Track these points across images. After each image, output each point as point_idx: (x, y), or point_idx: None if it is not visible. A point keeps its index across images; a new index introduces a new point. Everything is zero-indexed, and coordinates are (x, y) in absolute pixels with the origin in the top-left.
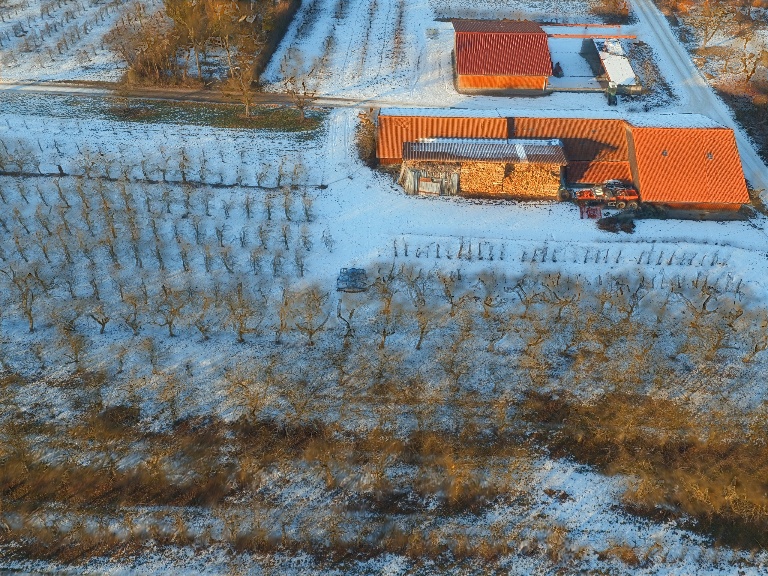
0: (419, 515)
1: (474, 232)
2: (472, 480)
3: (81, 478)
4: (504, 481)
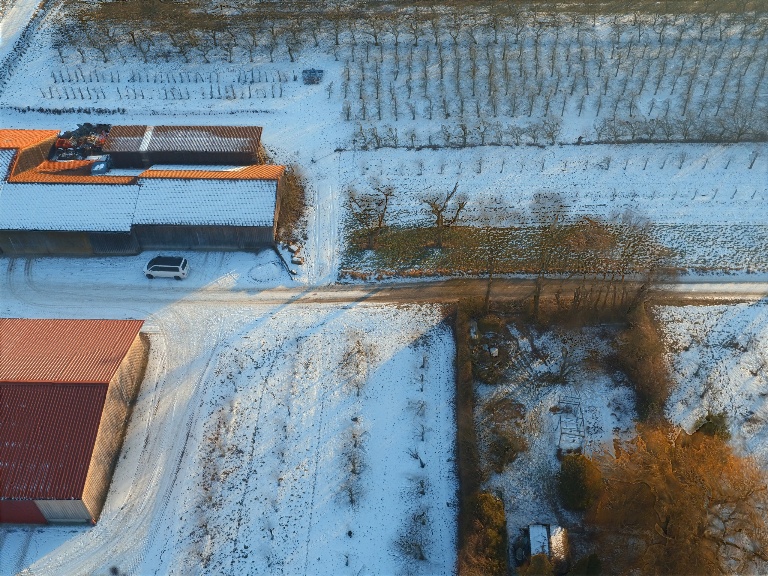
0: None
1: (215, 121)
2: None
3: (430, 4)
4: None
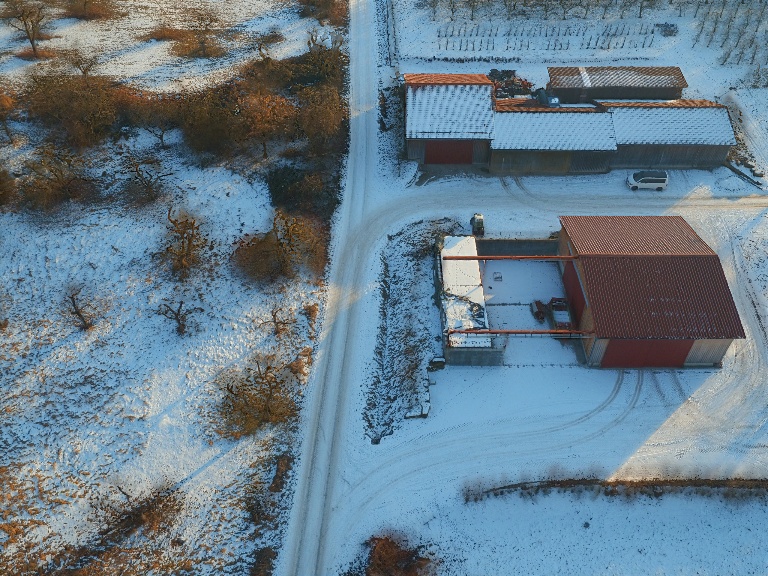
0: None
1: None
2: None
3: None
4: None
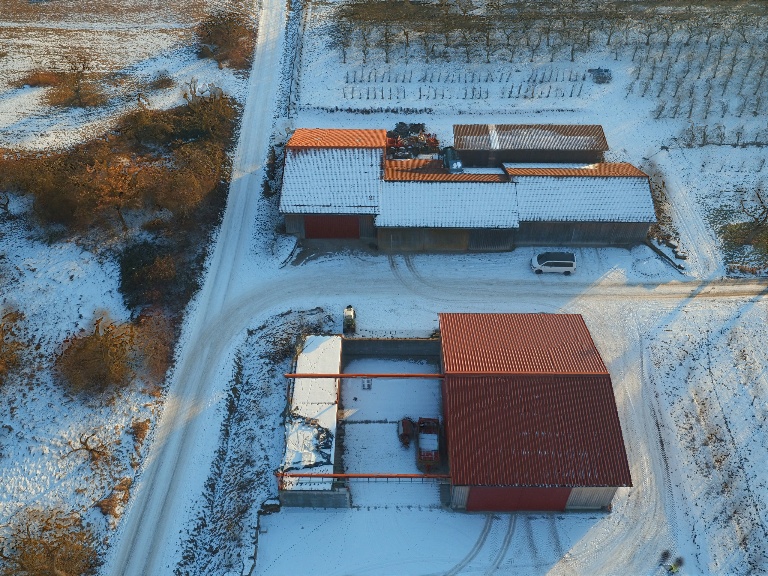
0: (533, 2)
1: (524, 120)
2: (513, 9)
3: (677, 4)
4: None
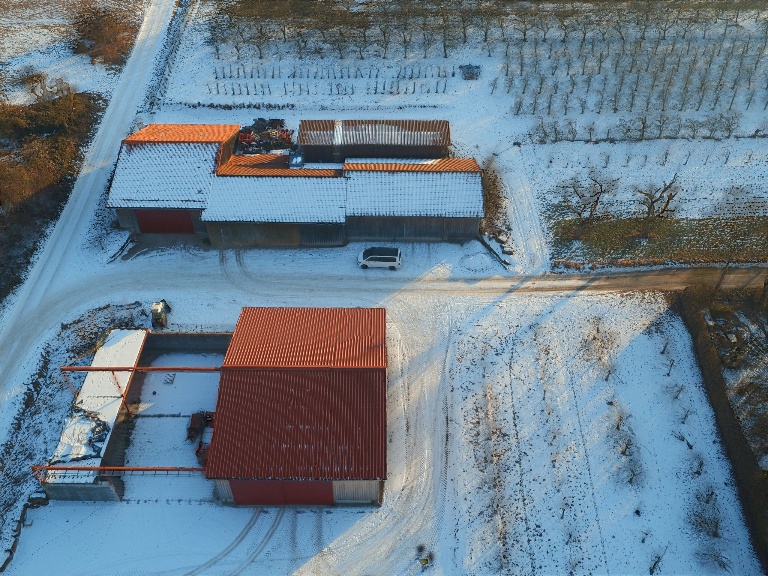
0: None
1: (385, 116)
2: (400, 6)
3: (565, 1)
4: (386, 6)
